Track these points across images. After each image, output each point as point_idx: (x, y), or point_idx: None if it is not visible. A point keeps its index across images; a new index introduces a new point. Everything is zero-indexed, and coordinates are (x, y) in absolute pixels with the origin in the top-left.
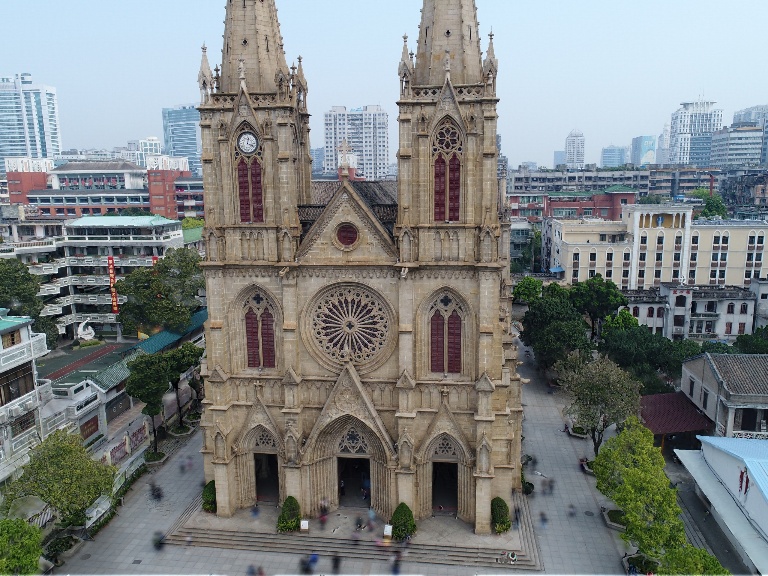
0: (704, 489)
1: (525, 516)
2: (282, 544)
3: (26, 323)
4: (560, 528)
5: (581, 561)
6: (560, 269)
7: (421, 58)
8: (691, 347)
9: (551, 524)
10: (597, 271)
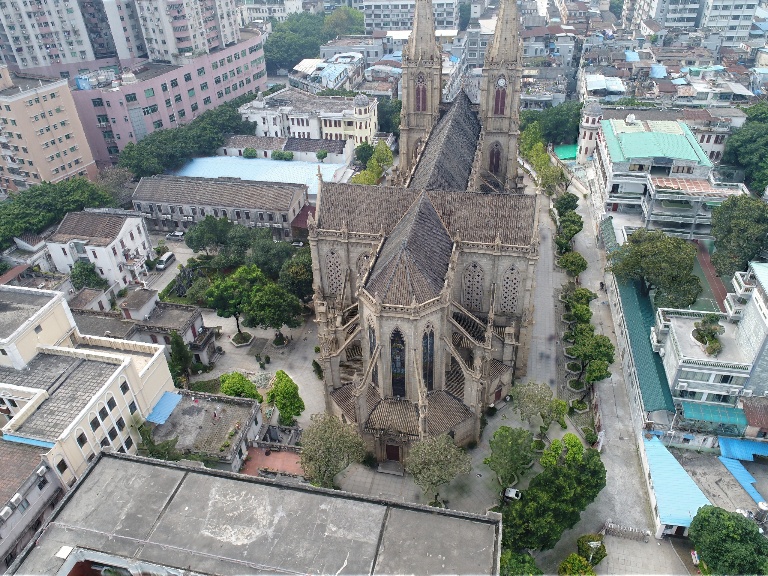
0: None
1: None
2: None
3: None
4: None
5: None
6: (161, 404)
7: (434, 44)
8: (256, 230)
9: None
10: None
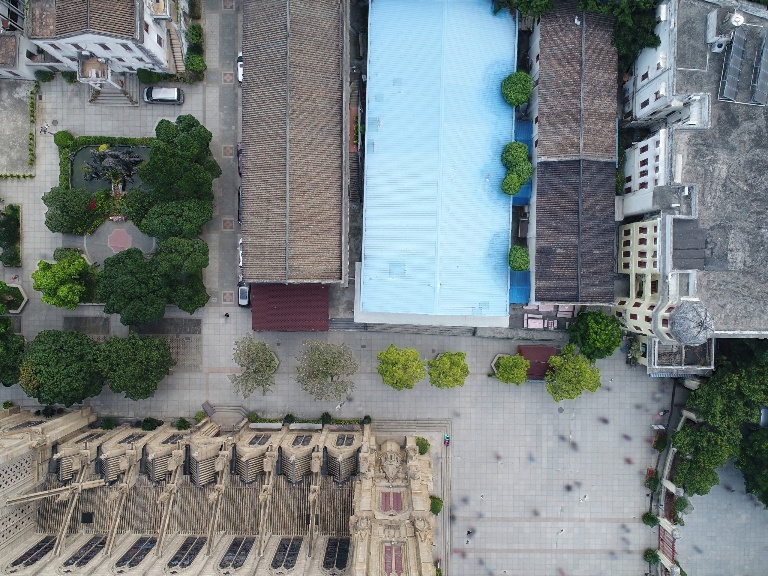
0: (412, 324)
1: (400, 425)
2: (446, 574)
3: None
4: (408, 403)
5: (440, 397)
6: None
7: None
8: (175, 248)
9: (404, 408)
10: None
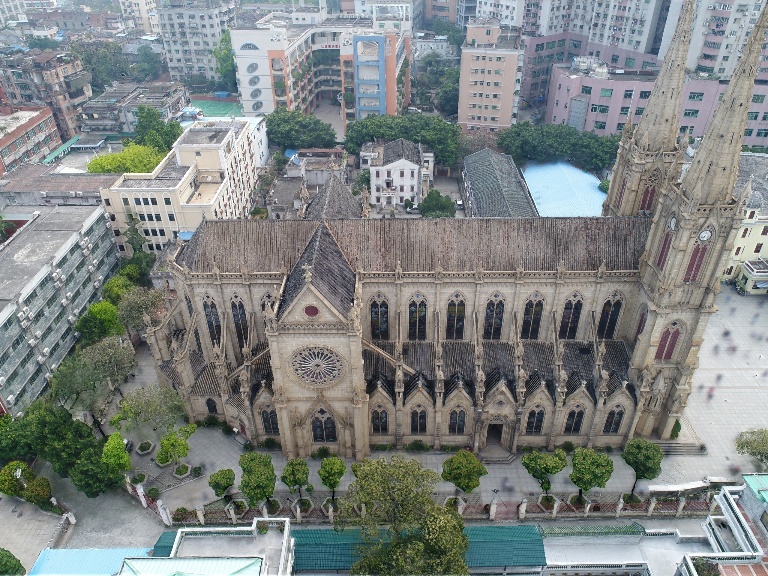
0: None
1: None
2: None
3: (753, 474)
4: None
5: None
6: None
7: None
8: None
9: None
10: (223, 216)
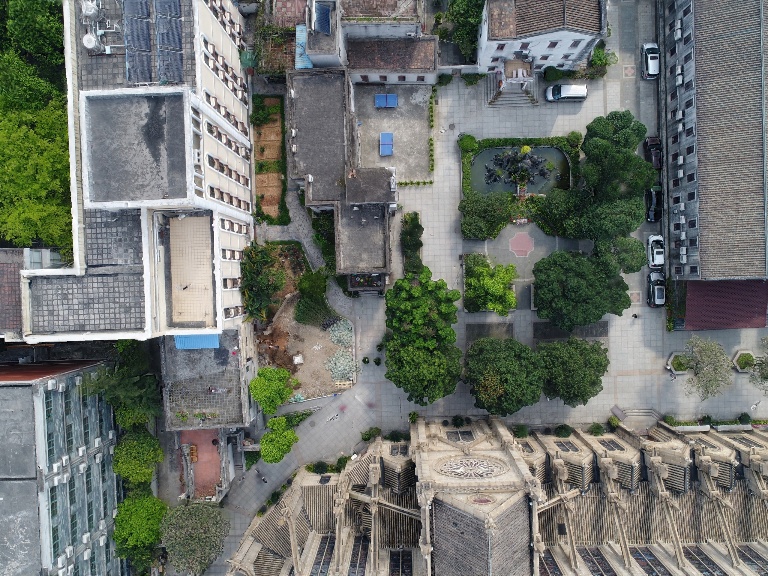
0: None
1: None
2: None
3: None
4: None
5: None
6: None
7: None
8: (626, 248)
9: None
10: (233, 275)
